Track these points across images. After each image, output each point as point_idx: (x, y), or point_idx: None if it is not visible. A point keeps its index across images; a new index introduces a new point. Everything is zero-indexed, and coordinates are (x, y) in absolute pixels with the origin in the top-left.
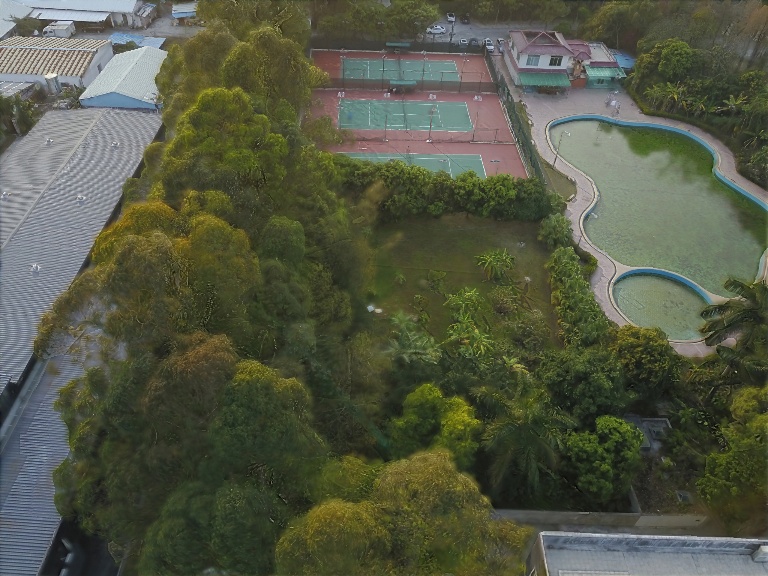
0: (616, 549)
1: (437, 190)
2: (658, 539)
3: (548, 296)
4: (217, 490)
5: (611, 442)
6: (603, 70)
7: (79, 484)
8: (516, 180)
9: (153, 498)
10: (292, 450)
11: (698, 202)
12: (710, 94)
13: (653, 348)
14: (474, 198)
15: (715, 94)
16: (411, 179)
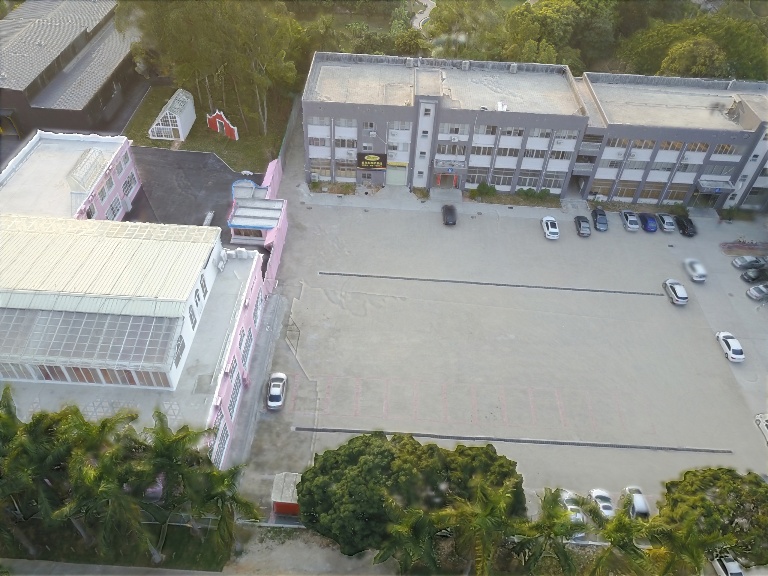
0: (349, 63)
1: None
2: (365, 56)
3: None
4: None
5: None
6: None
7: None
8: None
9: None
10: None
11: None
12: None
13: (412, 34)
14: None
15: None
16: None
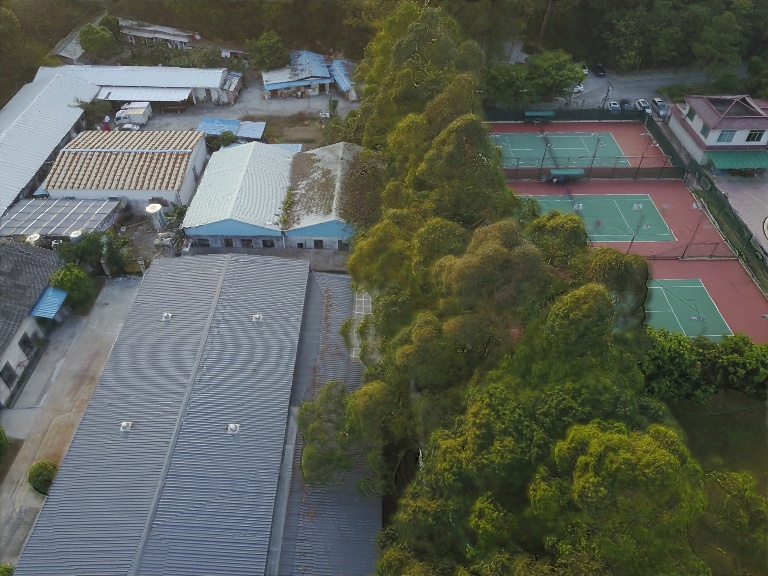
0: None
1: (705, 370)
2: None
3: None
4: None
5: None
6: None
7: None
8: None
9: None
10: None
11: None
12: None
13: None
14: (759, 380)
15: None
16: (672, 358)
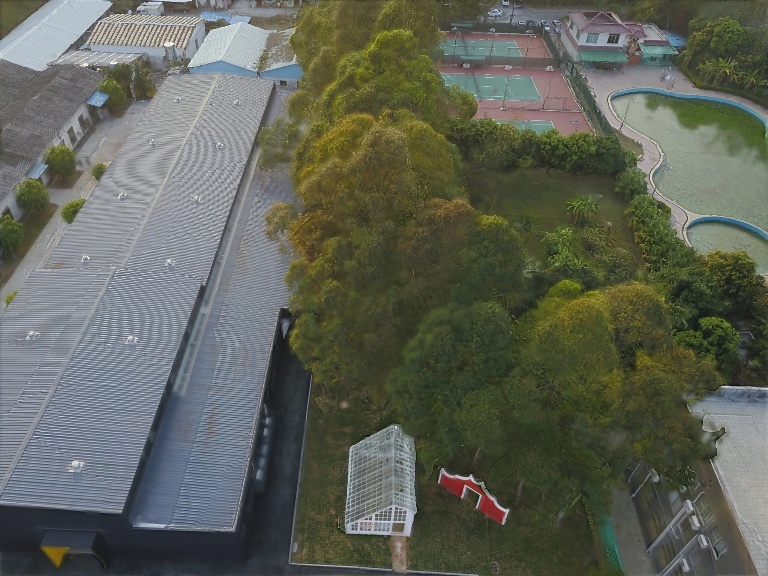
0: (739, 401)
1: (525, 145)
2: None
3: (629, 237)
4: (475, 305)
5: (715, 336)
6: (656, 48)
7: (321, 331)
8: (595, 137)
9: (404, 326)
10: (519, 284)
11: (754, 163)
12: (760, 68)
13: (742, 266)
14: (559, 153)
15: (765, 68)
16: (503, 135)
